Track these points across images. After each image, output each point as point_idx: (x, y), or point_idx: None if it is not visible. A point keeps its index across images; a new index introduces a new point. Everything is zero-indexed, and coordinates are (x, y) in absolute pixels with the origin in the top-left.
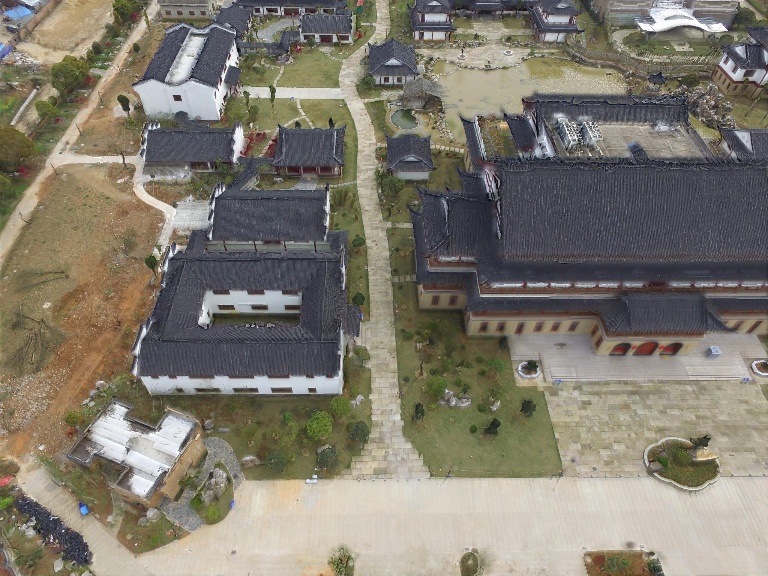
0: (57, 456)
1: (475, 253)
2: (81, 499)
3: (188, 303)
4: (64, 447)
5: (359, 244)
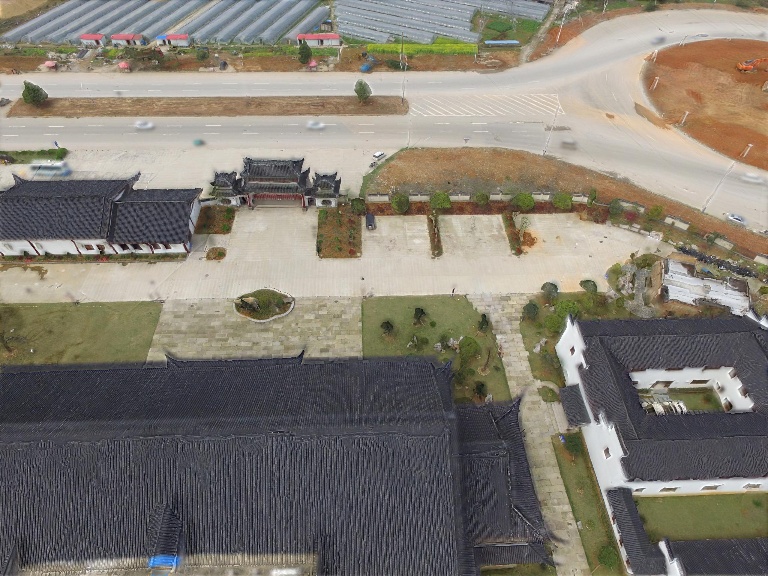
0: (759, 303)
1: (455, 412)
2: (713, 275)
3: (762, 381)
4: (760, 309)
5: (607, 547)
